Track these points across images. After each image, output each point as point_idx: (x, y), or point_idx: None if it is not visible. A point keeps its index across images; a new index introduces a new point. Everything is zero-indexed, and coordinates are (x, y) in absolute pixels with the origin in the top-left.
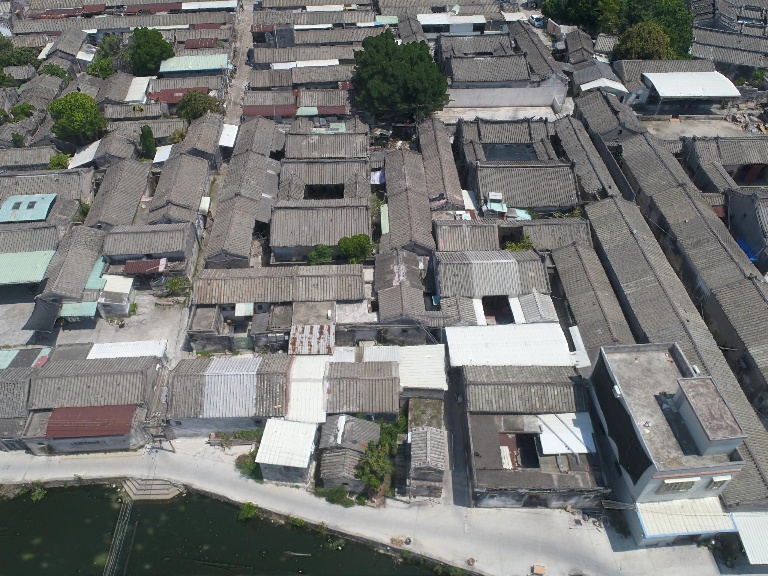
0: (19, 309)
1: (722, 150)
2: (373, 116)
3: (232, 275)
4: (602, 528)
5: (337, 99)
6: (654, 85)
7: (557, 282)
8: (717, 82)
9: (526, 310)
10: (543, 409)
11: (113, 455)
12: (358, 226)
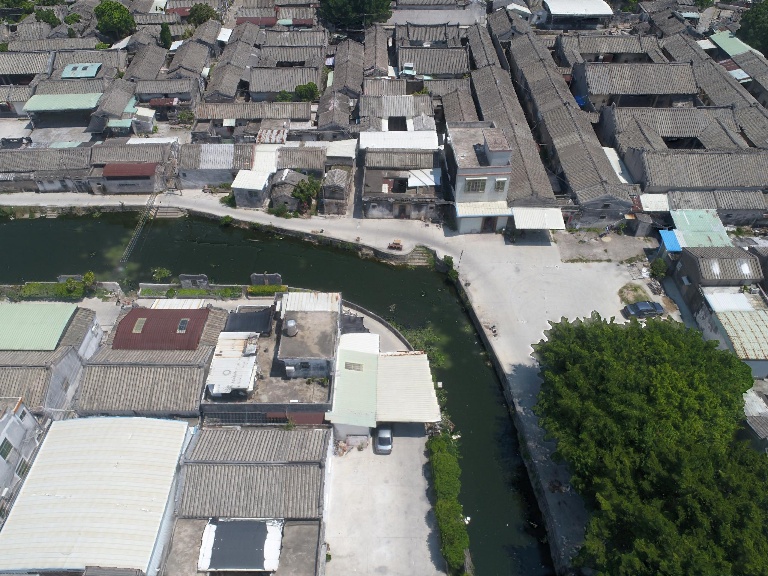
0: (78, 130)
1: (581, 43)
2: (334, 27)
3: None
4: (441, 228)
5: (307, 14)
6: (549, 7)
7: (444, 117)
8: (598, 5)
9: (416, 124)
10: (412, 166)
11: (143, 196)
12: (310, 80)
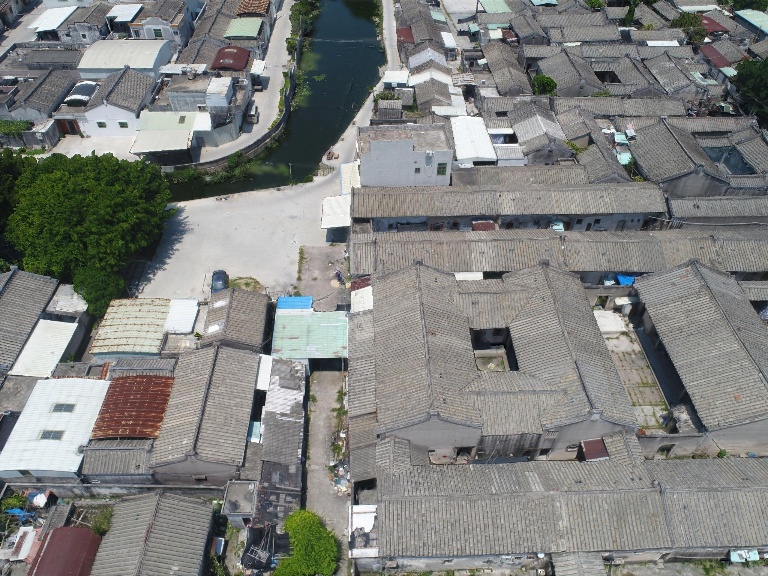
0: None
1: None
2: None
3: (504, 51)
4: None
5: None
6: None
7: None
8: None
9: (505, 146)
10: None
11: (398, 58)
12: (565, 82)
